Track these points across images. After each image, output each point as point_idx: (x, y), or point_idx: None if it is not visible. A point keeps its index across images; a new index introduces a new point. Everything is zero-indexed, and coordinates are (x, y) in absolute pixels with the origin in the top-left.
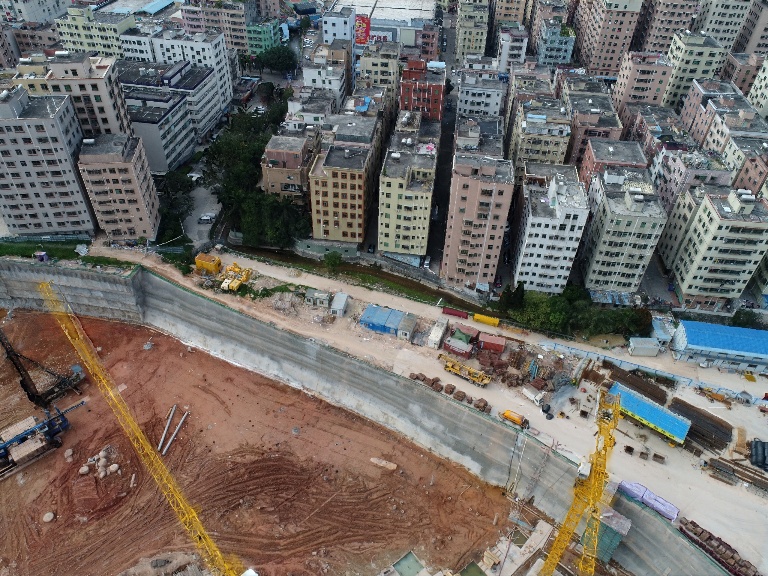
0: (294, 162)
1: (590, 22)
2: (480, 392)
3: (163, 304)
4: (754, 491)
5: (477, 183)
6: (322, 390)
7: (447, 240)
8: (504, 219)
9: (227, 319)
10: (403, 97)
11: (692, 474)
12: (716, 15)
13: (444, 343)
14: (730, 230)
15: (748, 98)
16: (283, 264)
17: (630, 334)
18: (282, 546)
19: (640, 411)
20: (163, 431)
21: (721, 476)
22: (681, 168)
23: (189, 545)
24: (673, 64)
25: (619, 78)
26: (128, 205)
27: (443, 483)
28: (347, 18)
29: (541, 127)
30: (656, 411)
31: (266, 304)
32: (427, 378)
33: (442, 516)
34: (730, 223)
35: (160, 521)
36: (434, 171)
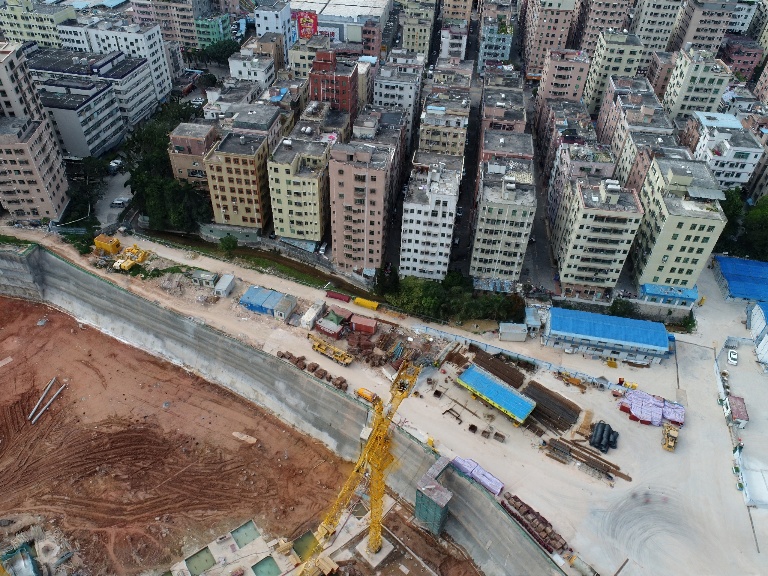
0: (199, 148)
1: (531, 21)
2: (342, 371)
3: (60, 282)
4: (584, 470)
5: (350, 169)
6: (200, 367)
7: (332, 225)
8: (380, 205)
9: (115, 297)
10: (312, 88)
11: (529, 453)
12: (648, 15)
13: (316, 324)
14: (595, 219)
15: (665, 96)
16: (182, 247)
17: (505, 320)
18: (128, 511)
19: (489, 392)
20: (37, 401)
21: (556, 455)
22: (567, 160)
23: (37, 507)
24: (597, 62)
25: (543, 75)
26: (28, 186)
27: (298, 457)
28: (278, 12)
29: (439, 118)
30: (504, 392)
31: (154, 284)
32: (293, 356)
33: (290, 488)
34: (594, 212)
35: (15, 485)
36: (323, 158)
